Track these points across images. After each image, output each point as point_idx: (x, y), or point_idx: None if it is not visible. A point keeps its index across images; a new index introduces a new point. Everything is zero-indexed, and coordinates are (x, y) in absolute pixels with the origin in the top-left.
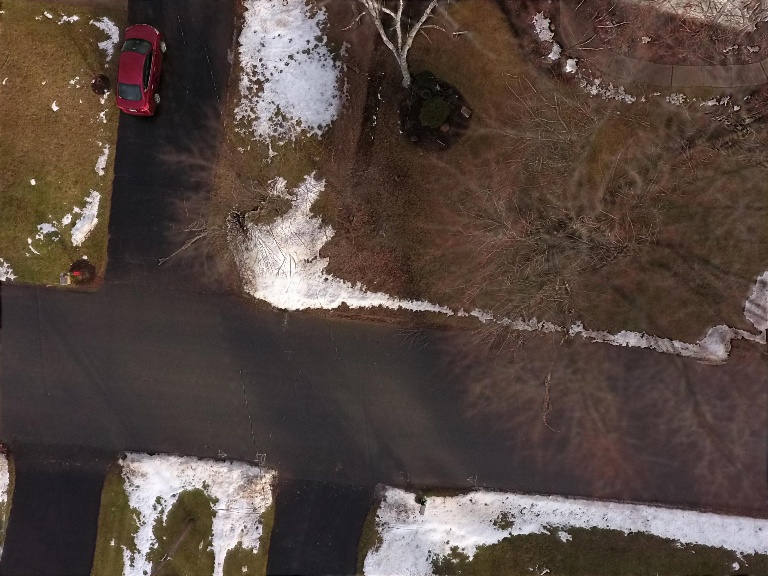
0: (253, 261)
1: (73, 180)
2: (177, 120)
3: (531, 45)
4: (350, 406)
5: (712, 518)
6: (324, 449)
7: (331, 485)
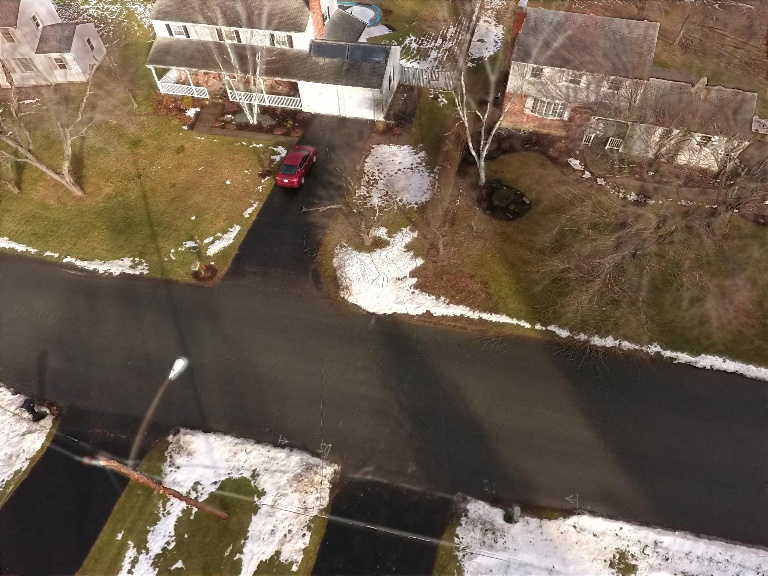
0: (352, 273)
1: (224, 218)
2: (312, 193)
3: (569, 172)
4: (429, 401)
5: None
6: (397, 445)
7: (401, 490)
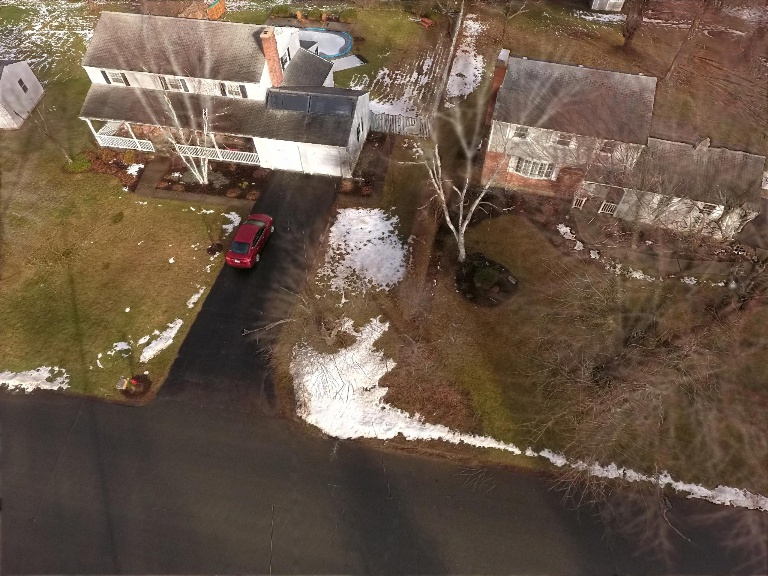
0: (312, 384)
1: (164, 310)
2: (269, 274)
3: (559, 242)
4: (401, 564)
5: None
6: None
7: None
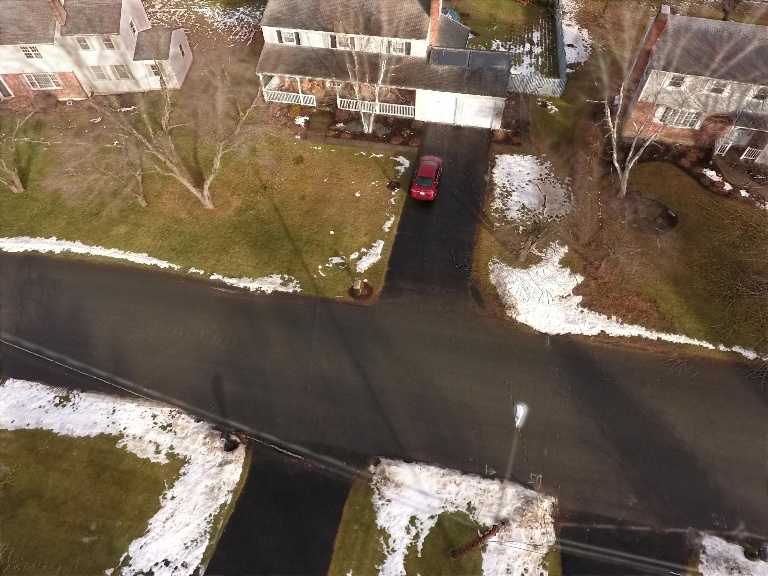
0: (515, 291)
1: (364, 233)
2: (448, 206)
3: (707, 183)
4: (631, 428)
5: None
6: (611, 475)
7: (628, 524)
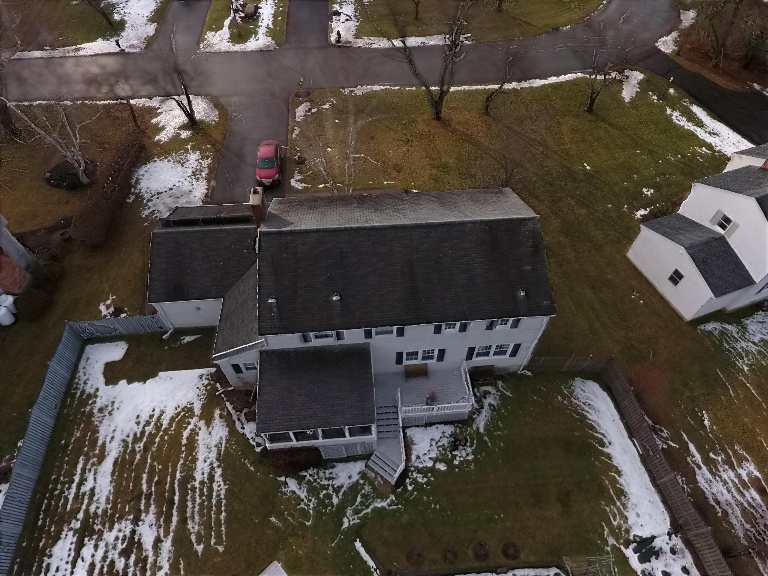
0: None
1: (313, 124)
2: (250, 153)
3: None
4: None
5: None
6: (171, 59)
7: (169, 51)
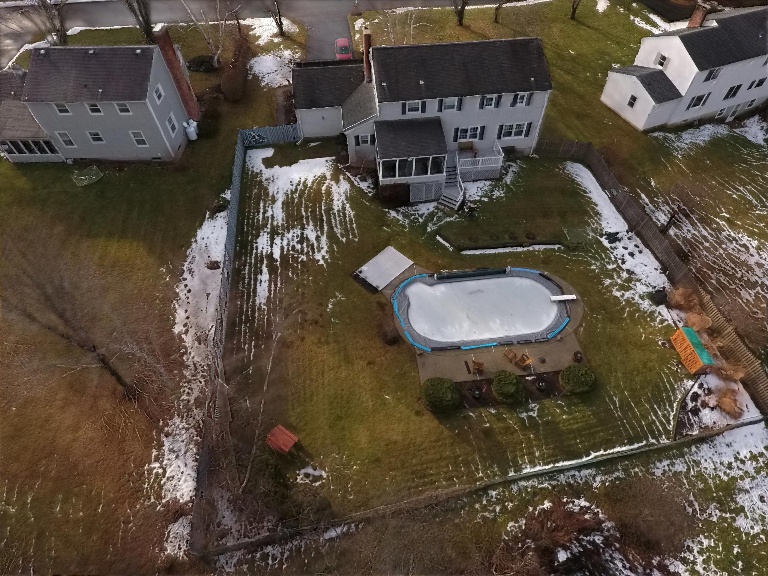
0: None
1: None
2: (327, 49)
3: None
4: (240, 3)
5: (90, 0)
6: None
7: None
